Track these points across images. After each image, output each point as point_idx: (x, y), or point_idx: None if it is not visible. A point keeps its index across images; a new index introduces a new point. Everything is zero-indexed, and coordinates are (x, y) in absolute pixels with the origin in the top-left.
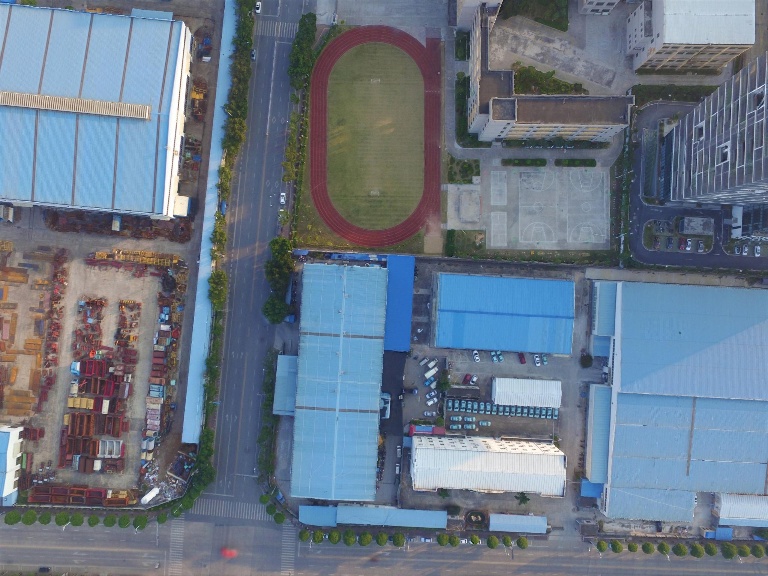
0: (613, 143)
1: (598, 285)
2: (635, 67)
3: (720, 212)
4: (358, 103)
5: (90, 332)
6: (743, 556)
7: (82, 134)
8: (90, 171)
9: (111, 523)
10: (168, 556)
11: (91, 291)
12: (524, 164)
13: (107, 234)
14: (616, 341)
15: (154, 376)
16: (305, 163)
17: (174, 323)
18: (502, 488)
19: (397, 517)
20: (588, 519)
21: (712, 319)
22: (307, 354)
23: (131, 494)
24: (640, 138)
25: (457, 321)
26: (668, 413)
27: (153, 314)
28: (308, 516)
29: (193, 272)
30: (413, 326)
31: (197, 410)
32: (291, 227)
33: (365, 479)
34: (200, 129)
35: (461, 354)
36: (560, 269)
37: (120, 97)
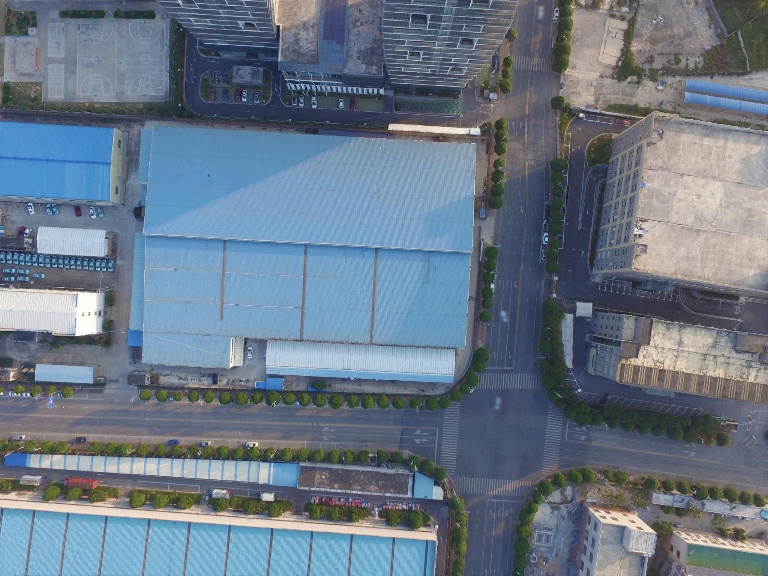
0: None
1: None
2: None
3: None
4: None
5: None
6: (287, 404)
7: None
8: None
9: None
10: None
11: None
12: (81, 16)
13: None
14: None
15: None
16: None
17: None
18: (13, 327)
19: None
20: (143, 371)
21: (243, 162)
22: None
23: None
24: None
25: None
26: (198, 257)
27: None
28: None
29: None
30: None
31: None
32: None
33: None
34: None
35: (17, 207)
36: (118, 122)
37: None
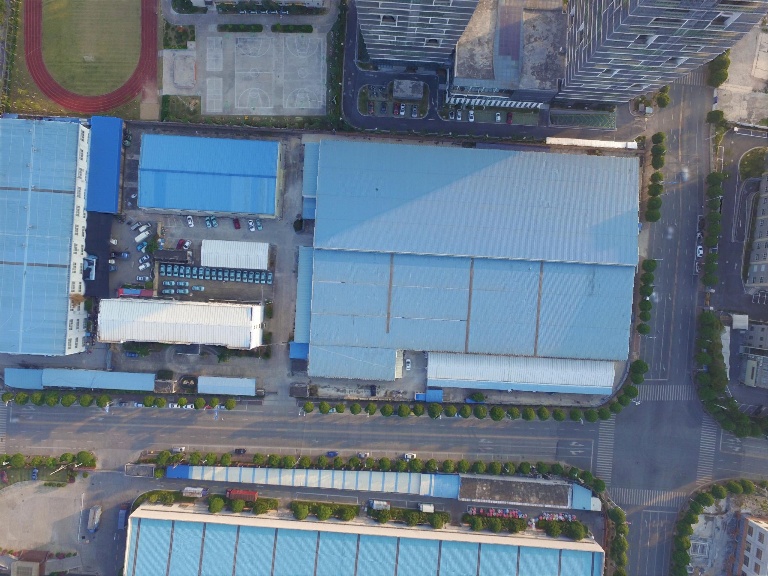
0: (330, 9)
1: None
2: None
3: (435, 77)
4: None
5: None
6: (449, 416)
7: None
8: None
9: None
10: None
11: None
12: (239, 29)
13: None
14: None
15: None
16: (19, 28)
17: None
18: (188, 340)
19: (103, 379)
20: (302, 383)
21: (410, 176)
22: None
23: None
24: None
25: (158, 180)
26: (366, 270)
27: None
28: (14, 379)
29: None
30: (127, 191)
31: None
32: (2, 92)
33: (54, 333)
34: None
35: (176, 220)
36: (276, 135)
37: None
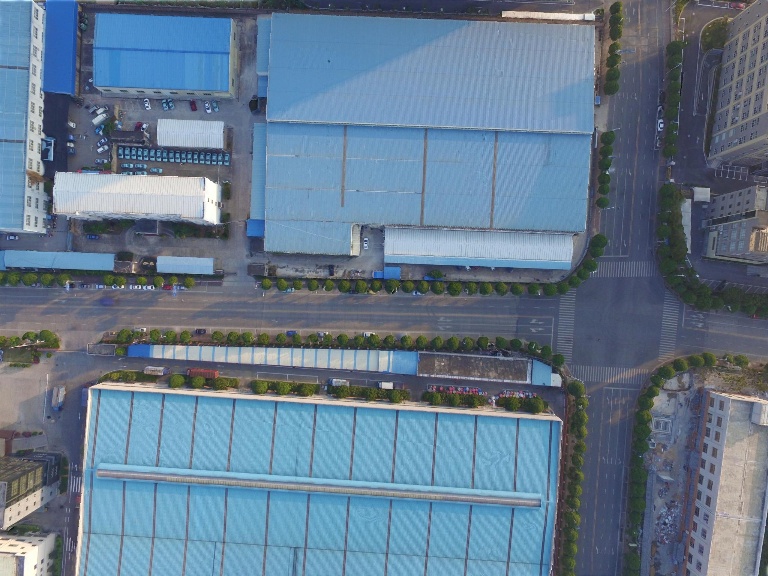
0: None
1: None
2: None
3: None
4: None
5: None
6: (406, 291)
7: None
8: None
9: None
10: None
11: None
12: None
13: None
14: None
15: None
16: None
17: None
18: (143, 211)
19: (64, 259)
20: None
21: (362, 47)
22: None
23: None
24: None
25: (113, 59)
26: (319, 143)
27: None
28: None
29: None
30: (84, 76)
31: None
32: None
33: (12, 208)
34: None
35: (133, 103)
36: (231, 16)
37: None
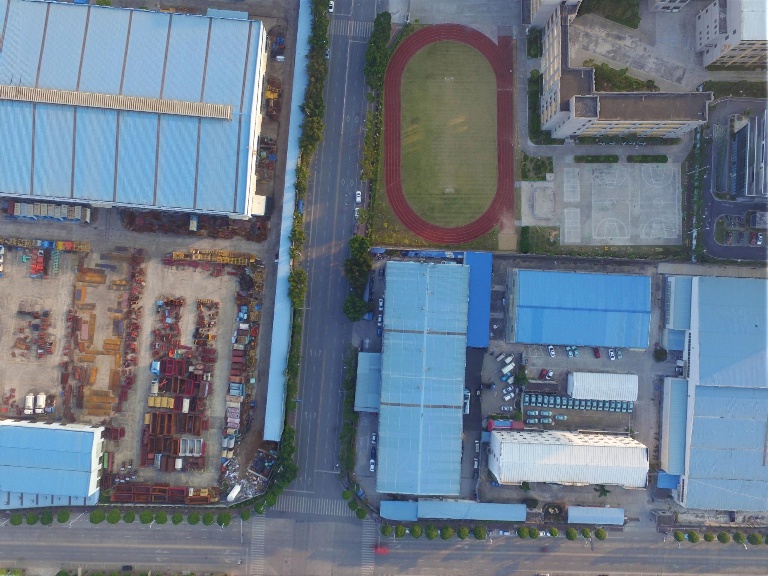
0: (684, 139)
1: (673, 280)
2: (705, 64)
3: None
4: (431, 101)
5: (169, 332)
6: None
7: (164, 134)
8: (172, 171)
9: (195, 521)
10: (250, 552)
11: (169, 291)
12: (597, 161)
13: (184, 234)
14: (692, 335)
15: (234, 375)
16: (380, 161)
17: (252, 322)
18: (586, 481)
19: (477, 511)
20: (663, 510)
21: None
22: (391, 351)
23: (212, 492)
24: (711, 134)
25: (536, 317)
26: (745, 405)
27: (231, 313)
28: (389, 511)
29: (270, 271)
30: (489, 322)
31: (282, 408)
32: (367, 225)
33: (450, 474)
34: (275, 128)
35: (536, 349)
36: (633, 264)
37: (201, 97)
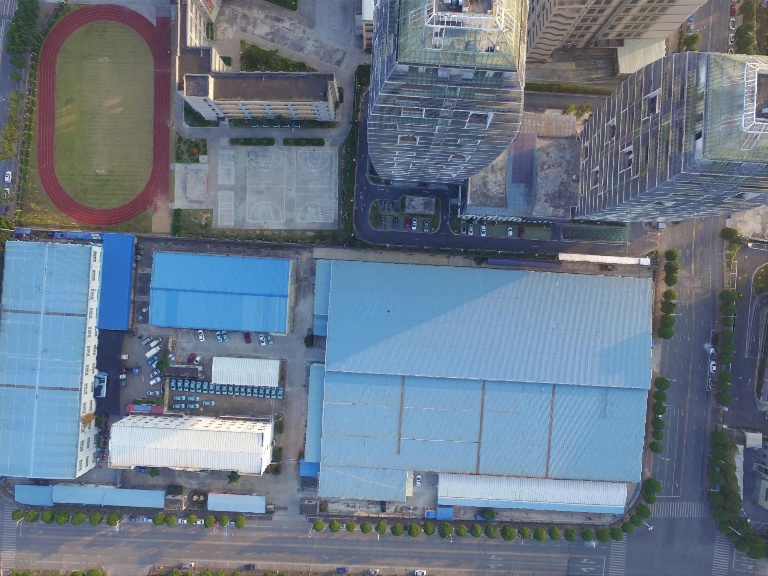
0: (342, 122)
1: None
2: (364, 46)
3: (447, 192)
4: (87, 82)
5: None
6: None
7: None
8: None
9: None
10: None
11: None
12: (251, 143)
13: None
14: None
15: None
16: (32, 142)
17: None
18: (199, 466)
19: (113, 496)
20: (312, 499)
21: (422, 297)
22: (8, 331)
23: None
24: None
25: (170, 299)
26: (377, 392)
27: None
28: (24, 495)
29: None
30: (138, 305)
31: None
32: (15, 206)
33: (65, 457)
34: None
35: (187, 333)
36: (287, 248)
37: None
